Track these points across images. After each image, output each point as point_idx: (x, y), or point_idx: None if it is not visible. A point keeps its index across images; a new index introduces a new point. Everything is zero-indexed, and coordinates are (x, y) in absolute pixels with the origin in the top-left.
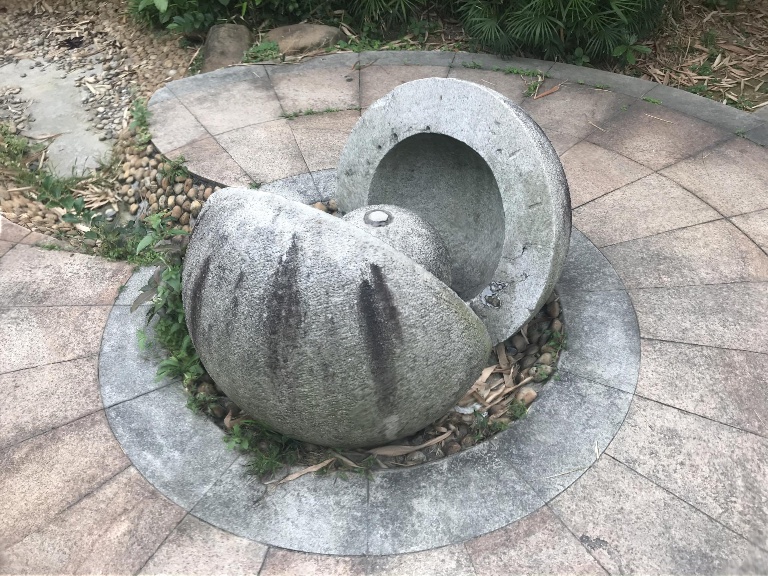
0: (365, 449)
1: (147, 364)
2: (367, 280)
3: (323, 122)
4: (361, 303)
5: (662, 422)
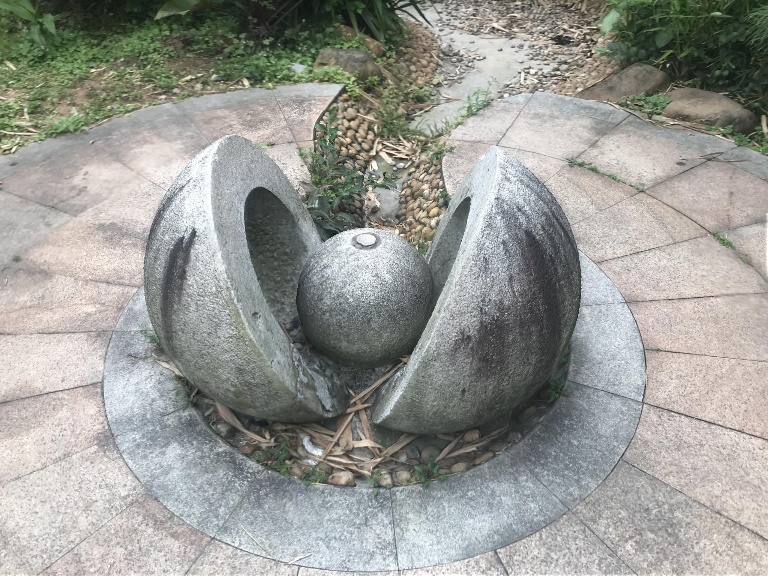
0: None
1: None
2: (185, 238)
3: (590, 182)
4: (173, 251)
5: None
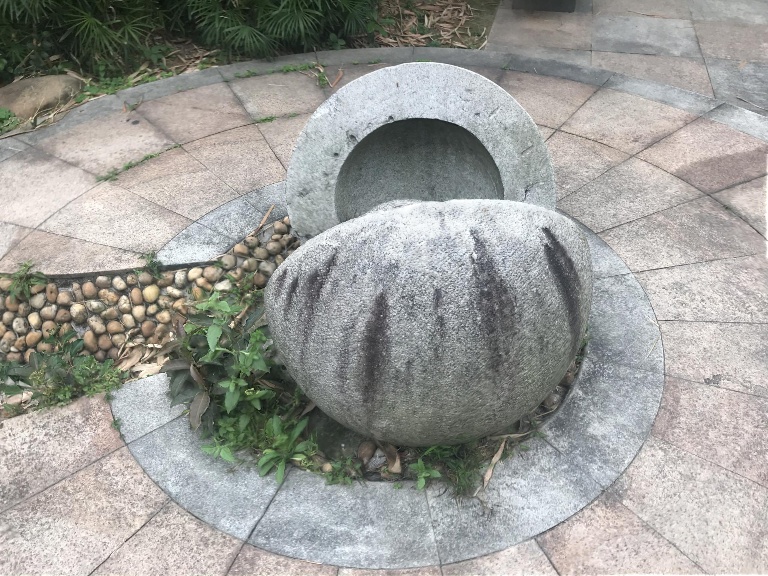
0: None
1: (239, 475)
2: (546, 244)
3: (154, 170)
4: (551, 266)
5: (666, 281)
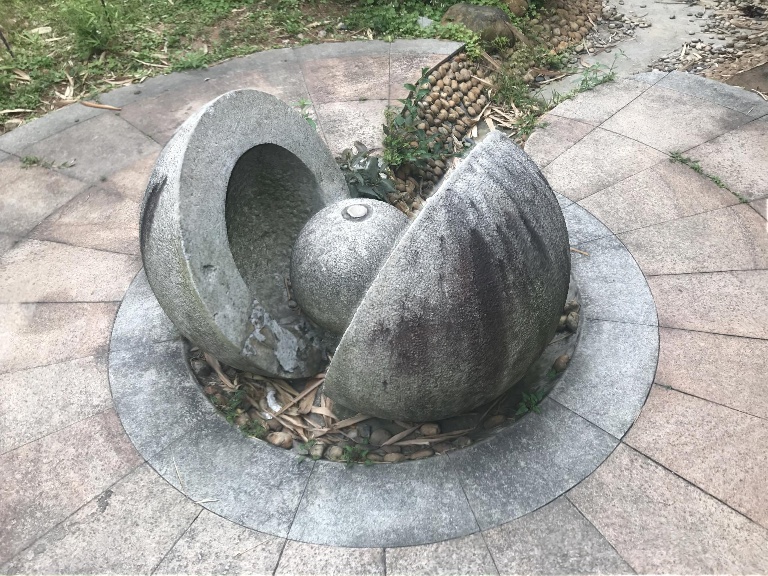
0: None
1: None
2: None
3: (686, 183)
4: None
5: (246, 568)
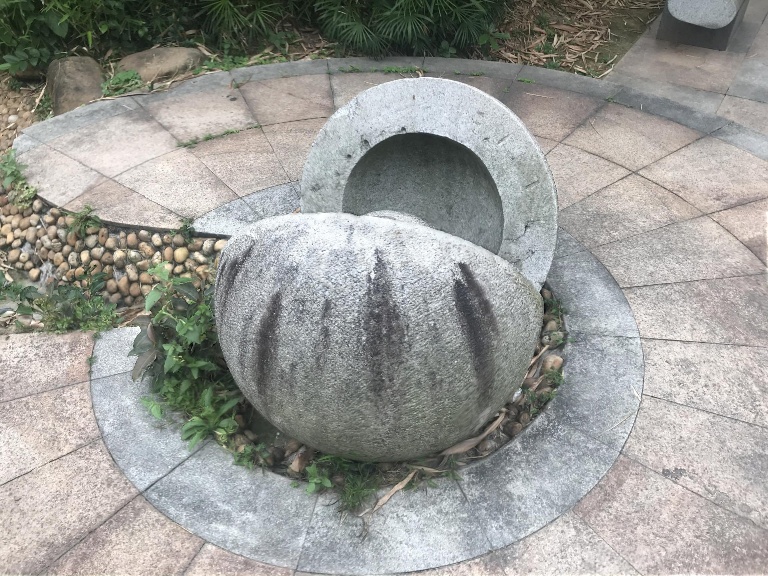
0: (437, 453)
1: (165, 433)
2: (459, 279)
3: (228, 145)
4: (459, 303)
5: (674, 355)
